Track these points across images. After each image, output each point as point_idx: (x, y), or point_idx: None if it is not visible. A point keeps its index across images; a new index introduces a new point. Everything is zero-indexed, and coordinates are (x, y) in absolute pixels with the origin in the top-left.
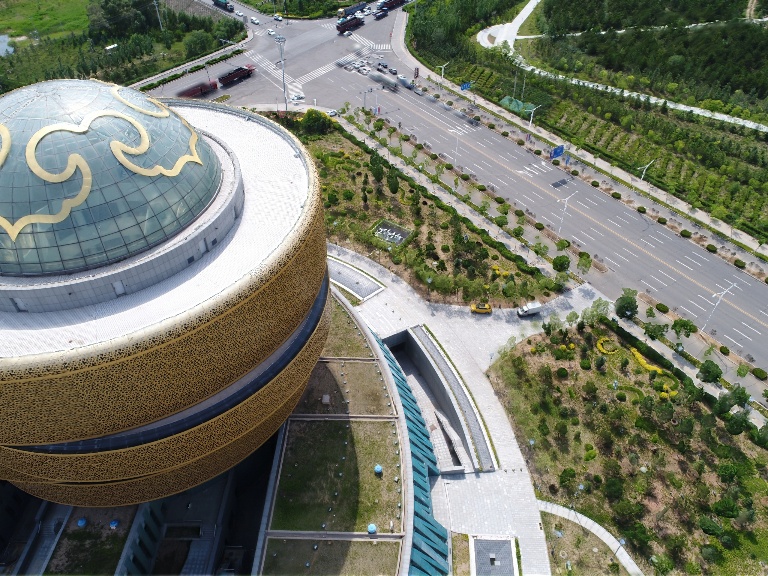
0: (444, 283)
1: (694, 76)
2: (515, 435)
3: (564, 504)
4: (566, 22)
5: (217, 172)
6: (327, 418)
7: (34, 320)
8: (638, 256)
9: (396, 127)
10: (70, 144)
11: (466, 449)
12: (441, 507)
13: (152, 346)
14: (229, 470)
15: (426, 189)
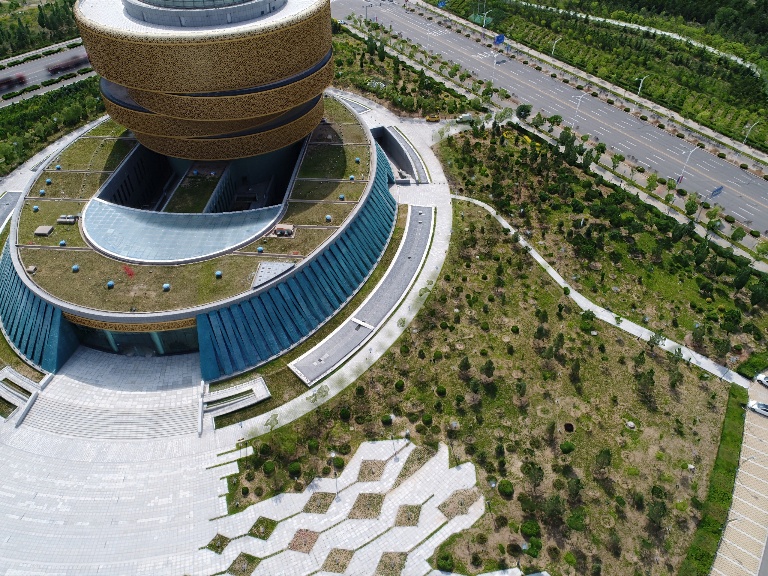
0: (409, 101)
1: None
2: (443, 171)
3: (466, 196)
4: None
5: None
6: (330, 143)
7: (190, 28)
8: (543, 97)
9: (388, 30)
10: None
11: (413, 176)
12: (394, 194)
13: (247, 36)
14: (272, 175)
15: (405, 63)
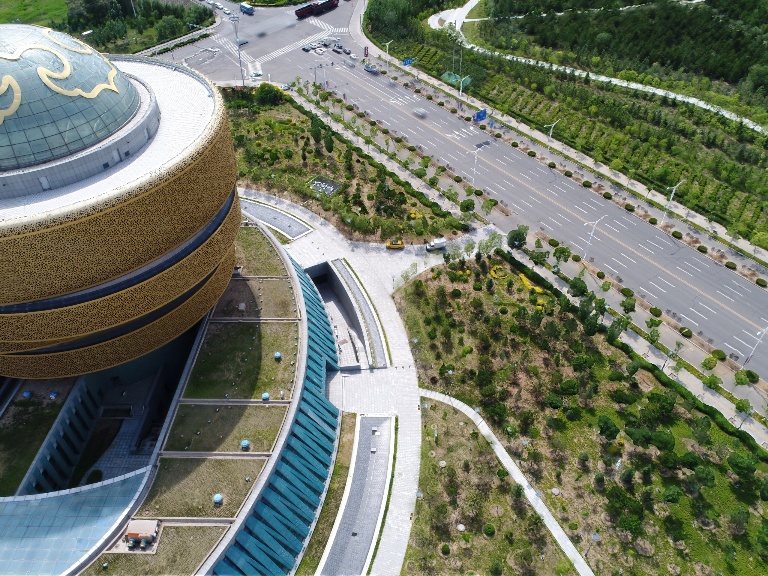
0: (362, 222)
1: (618, 51)
2: (409, 341)
3: (441, 391)
4: (510, 6)
5: (135, 102)
6: (241, 320)
7: None
8: (541, 202)
9: (342, 99)
10: (4, 68)
11: (365, 352)
12: (337, 394)
13: (66, 222)
14: (159, 366)
15: (361, 150)
